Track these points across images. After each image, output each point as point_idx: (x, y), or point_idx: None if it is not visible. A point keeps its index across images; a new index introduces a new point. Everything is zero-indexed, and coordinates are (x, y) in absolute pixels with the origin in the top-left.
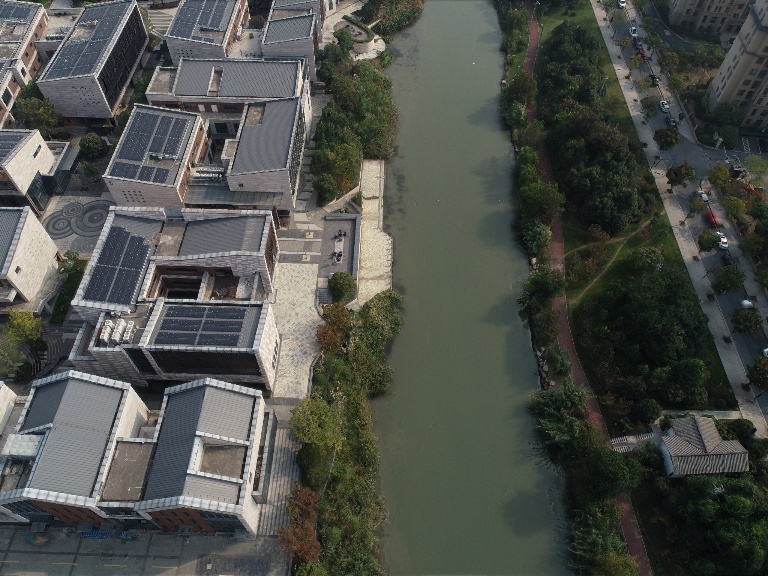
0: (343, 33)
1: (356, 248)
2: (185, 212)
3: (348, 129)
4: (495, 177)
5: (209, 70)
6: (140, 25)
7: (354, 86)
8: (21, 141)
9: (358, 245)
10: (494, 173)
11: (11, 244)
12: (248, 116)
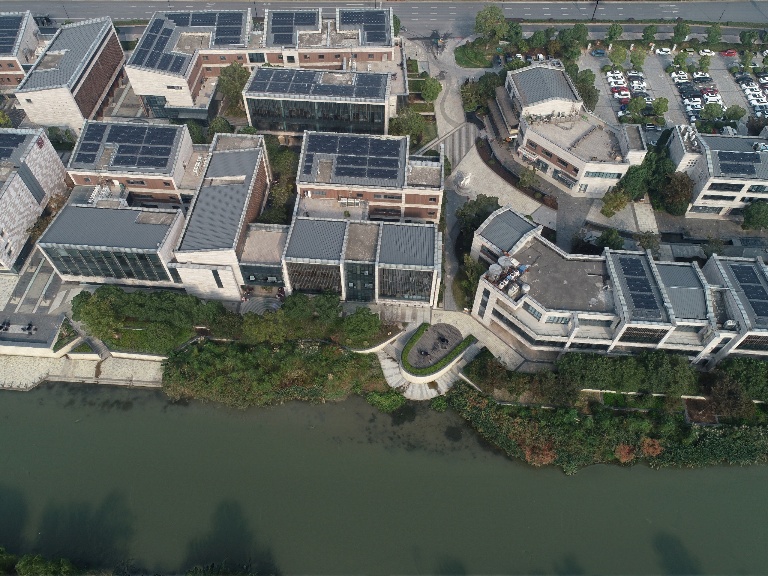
0: (358, 314)
1: (1, 342)
2: (11, 174)
3: (202, 337)
4: (89, 535)
5: (241, 173)
6: (380, 122)
7: (272, 339)
8: (169, 72)
9: (4, 344)
10: (97, 534)
11: (37, 87)
12: (159, 214)
